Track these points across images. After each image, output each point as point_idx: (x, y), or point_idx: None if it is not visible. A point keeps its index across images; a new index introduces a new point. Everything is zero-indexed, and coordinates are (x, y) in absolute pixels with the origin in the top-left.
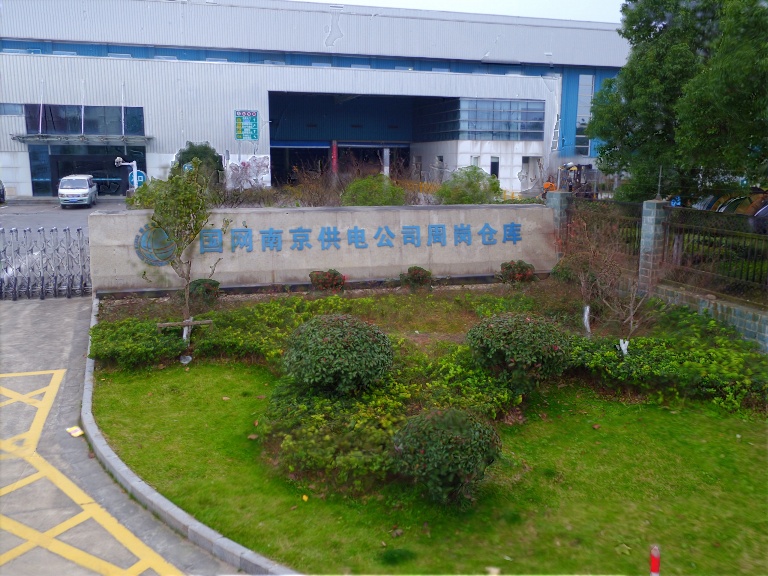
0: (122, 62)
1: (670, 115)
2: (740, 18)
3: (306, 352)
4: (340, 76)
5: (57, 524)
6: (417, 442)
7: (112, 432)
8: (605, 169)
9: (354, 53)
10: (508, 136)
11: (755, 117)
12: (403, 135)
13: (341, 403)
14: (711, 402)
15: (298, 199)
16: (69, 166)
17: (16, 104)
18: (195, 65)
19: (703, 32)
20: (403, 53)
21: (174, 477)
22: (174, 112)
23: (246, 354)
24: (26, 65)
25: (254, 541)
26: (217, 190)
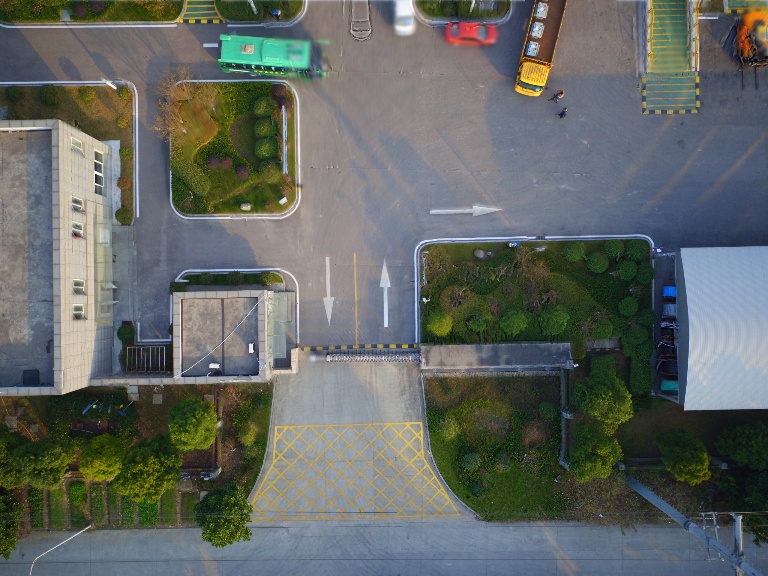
0: None
1: None
2: None
3: None
4: None
5: (431, 479)
6: None
7: (435, 457)
8: None
9: None
10: None
11: None
12: None
13: None
14: None
15: None
16: None
17: None
18: None
19: None
20: None
21: (444, 474)
22: None
23: None
24: None
25: (453, 490)
26: None
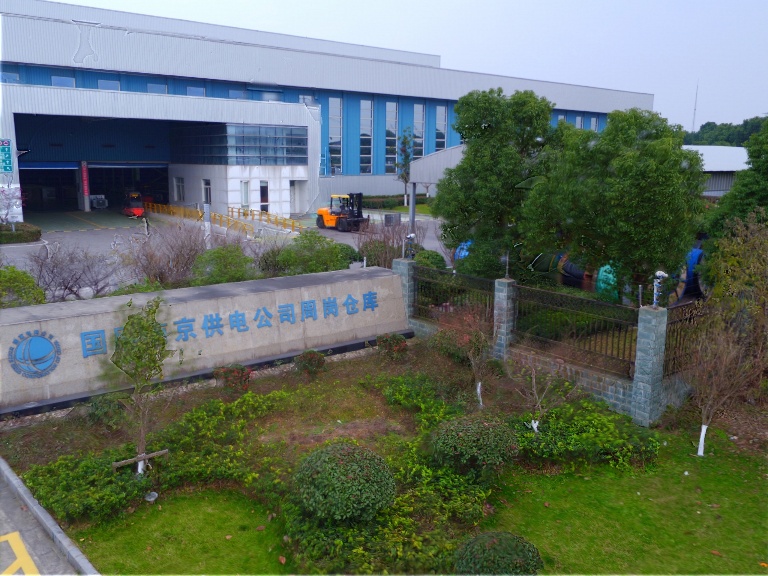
0: None
1: (504, 204)
2: (580, 152)
3: (334, 491)
4: (97, 98)
5: None
6: (491, 572)
7: None
8: (449, 244)
9: (102, 68)
10: (275, 161)
11: (592, 227)
12: (160, 155)
13: (367, 531)
14: (607, 465)
15: (128, 265)
16: None
17: None
18: None
19: (523, 136)
20: (156, 70)
21: None
22: None
23: (214, 480)
24: None
25: None
26: (51, 269)
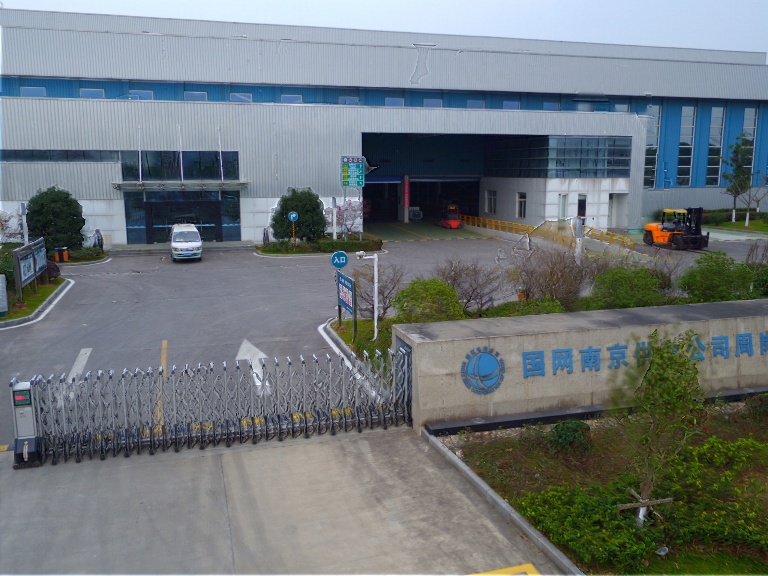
0: (218, 106)
1: None
2: None
3: None
4: (432, 116)
5: None
6: None
7: None
8: None
9: (429, 88)
10: (595, 173)
11: None
12: (474, 169)
13: None
14: None
15: (511, 280)
16: (163, 212)
17: (112, 151)
18: (290, 108)
19: None
20: (476, 87)
21: None
22: (269, 156)
23: (731, 544)
24: (123, 111)
25: None
26: (457, 282)
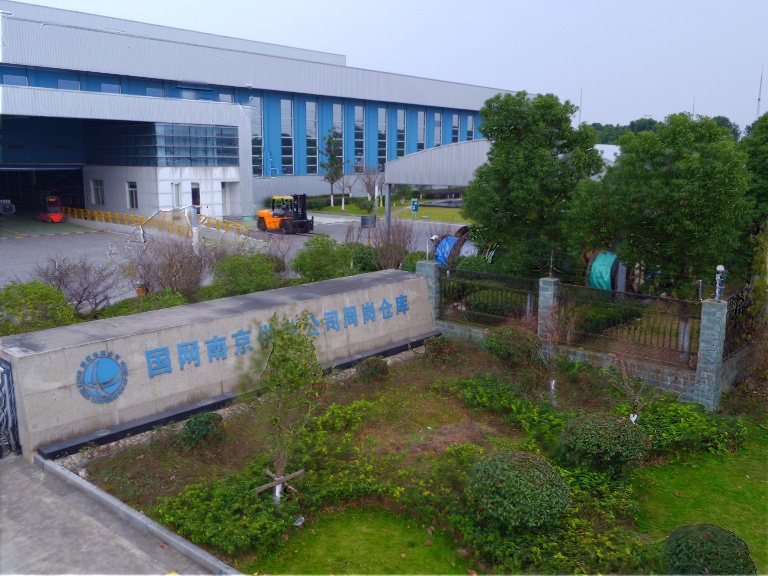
0: None
1: (538, 205)
2: (639, 154)
3: (525, 499)
4: (16, 95)
5: None
6: (718, 564)
7: None
8: (479, 245)
9: (8, 62)
10: (206, 162)
11: (648, 226)
12: (75, 156)
13: (554, 535)
14: (705, 452)
15: (127, 276)
16: None
17: None
18: None
19: (551, 138)
20: (68, 66)
21: None
22: None
23: (356, 498)
24: None
25: None
26: None
